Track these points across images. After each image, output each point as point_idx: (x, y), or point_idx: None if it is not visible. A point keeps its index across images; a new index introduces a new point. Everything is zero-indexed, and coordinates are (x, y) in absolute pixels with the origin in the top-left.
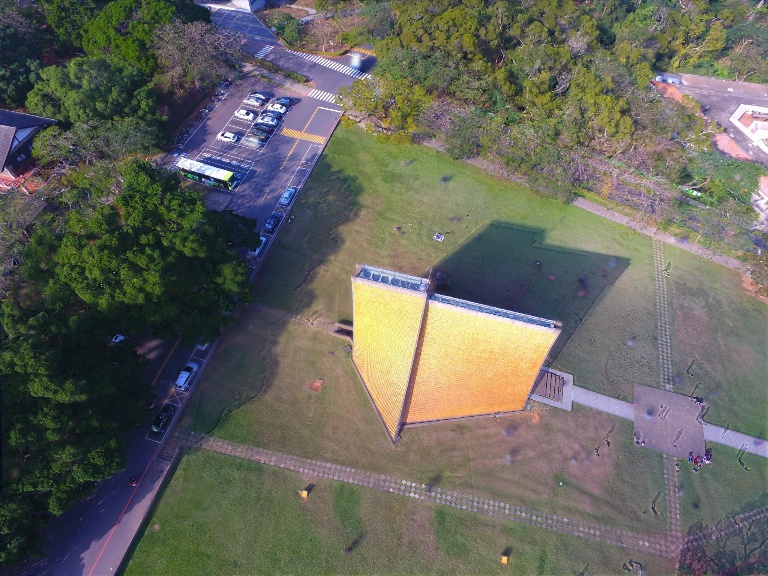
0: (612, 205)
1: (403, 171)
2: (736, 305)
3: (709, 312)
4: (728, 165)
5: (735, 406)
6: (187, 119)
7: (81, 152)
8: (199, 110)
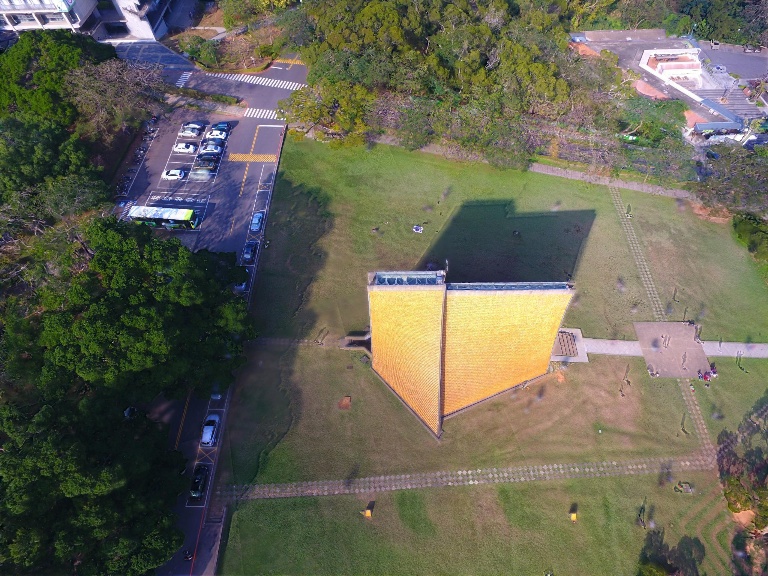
0: (564, 164)
1: (363, 172)
2: (694, 230)
3: (675, 242)
4: (656, 106)
5: (721, 320)
6: (122, 165)
7: (22, 223)
8: (133, 153)
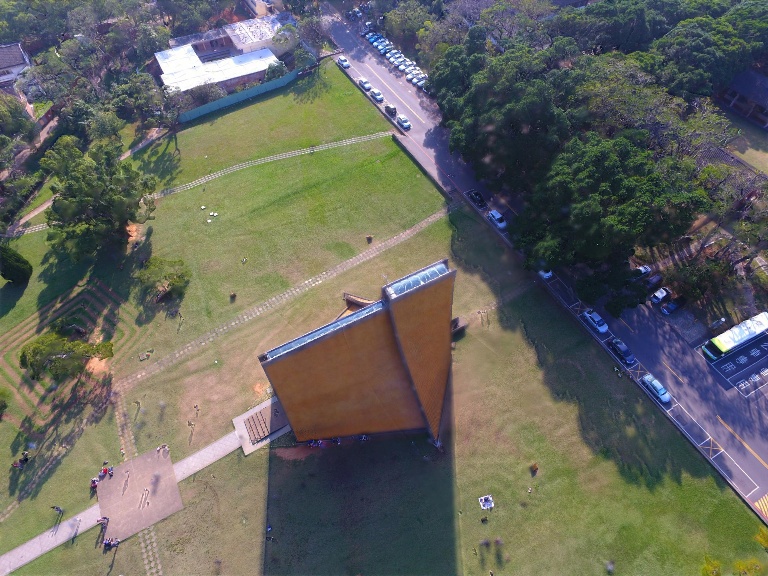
0: None
1: (634, 571)
2: None
3: None
4: None
5: None
6: None
7: None
8: None
